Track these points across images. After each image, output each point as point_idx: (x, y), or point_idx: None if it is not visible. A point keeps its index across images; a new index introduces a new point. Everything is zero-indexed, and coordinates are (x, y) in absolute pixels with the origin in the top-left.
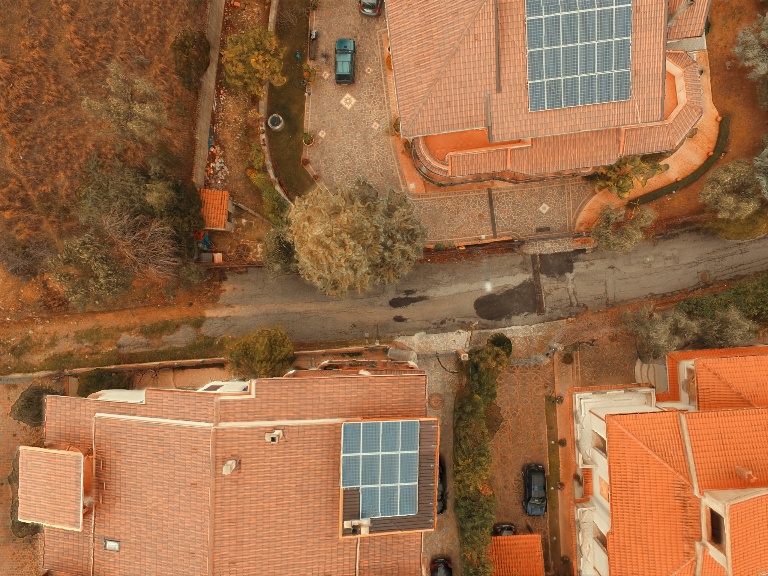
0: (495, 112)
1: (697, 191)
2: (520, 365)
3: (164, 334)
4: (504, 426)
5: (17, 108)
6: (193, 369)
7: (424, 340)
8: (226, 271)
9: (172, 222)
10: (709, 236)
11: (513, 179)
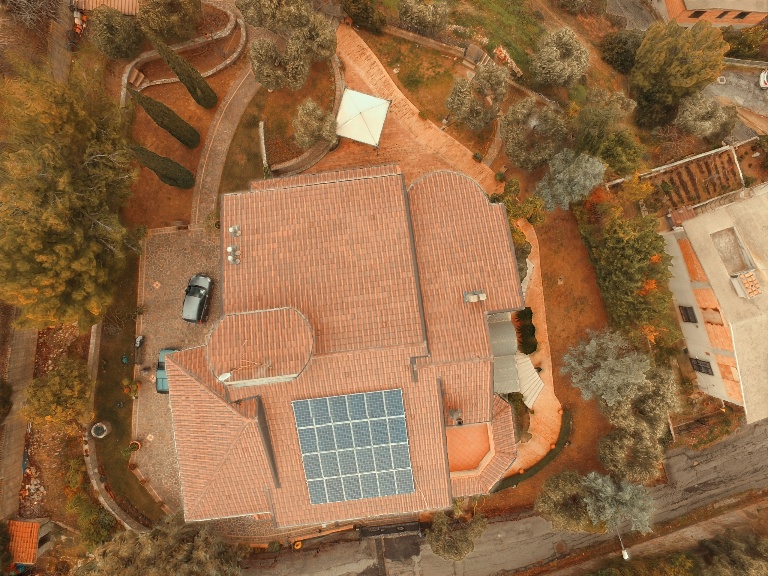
0: (277, 504)
1: (542, 479)
2: None
3: None
4: None
5: None
6: None
7: None
8: None
9: None
10: None
11: None
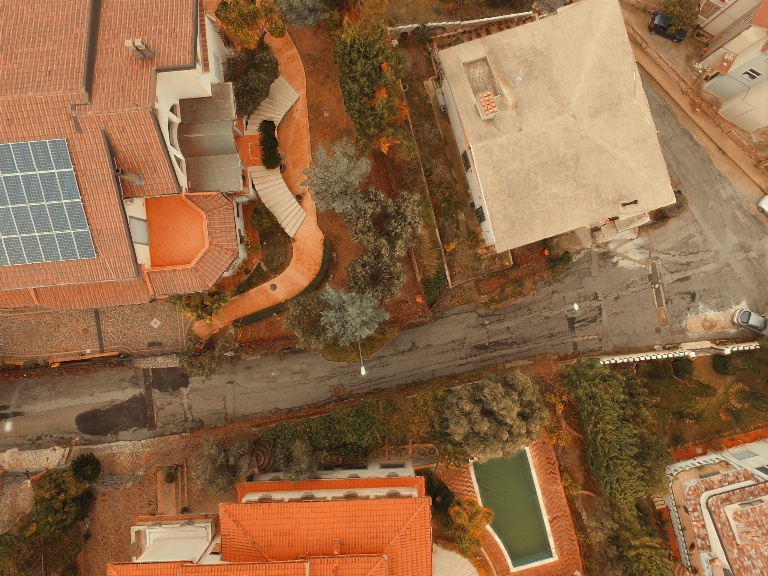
0: None
1: None
2: (124, 482)
3: None
4: (106, 543)
5: None
6: None
7: (15, 457)
8: None
9: None
10: None
11: None
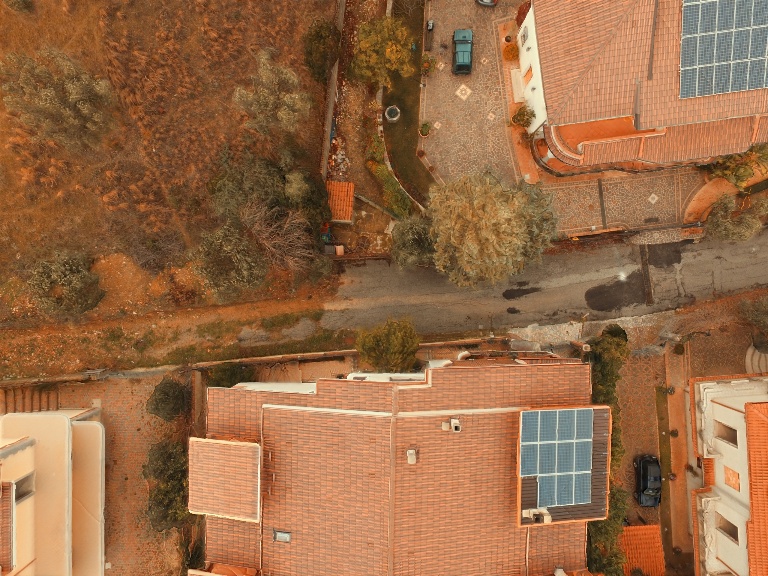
0: (645, 99)
1: None
2: (630, 356)
3: (284, 327)
4: None
5: (151, 100)
6: (313, 362)
7: (537, 332)
8: (344, 264)
9: (307, 214)
10: None
11: None
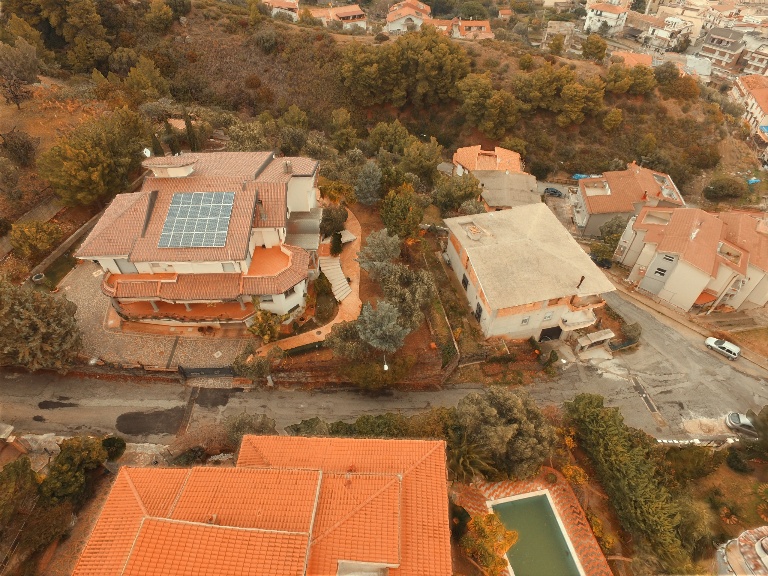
0: (137, 247)
1: None
2: None
3: None
4: (81, 549)
5: None
6: None
7: (49, 440)
8: None
9: None
10: (368, 398)
11: (180, 318)
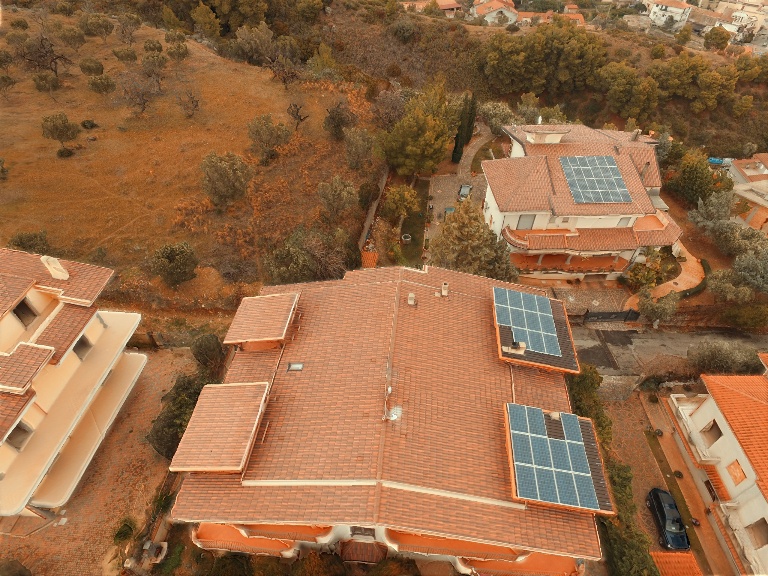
0: (555, 203)
1: (706, 298)
2: (611, 403)
3: None
4: None
5: (266, 202)
6: None
7: None
8: None
9: (347, 251)
10: (734, 339)
11: (569, 269)
